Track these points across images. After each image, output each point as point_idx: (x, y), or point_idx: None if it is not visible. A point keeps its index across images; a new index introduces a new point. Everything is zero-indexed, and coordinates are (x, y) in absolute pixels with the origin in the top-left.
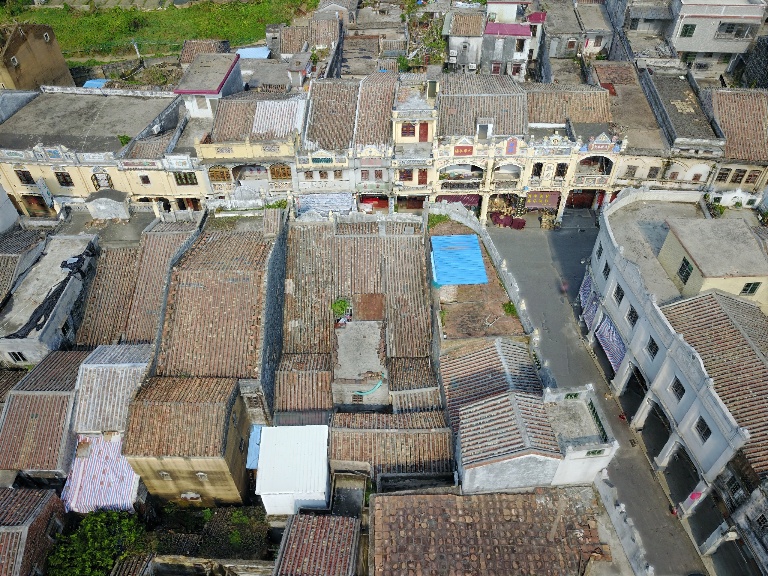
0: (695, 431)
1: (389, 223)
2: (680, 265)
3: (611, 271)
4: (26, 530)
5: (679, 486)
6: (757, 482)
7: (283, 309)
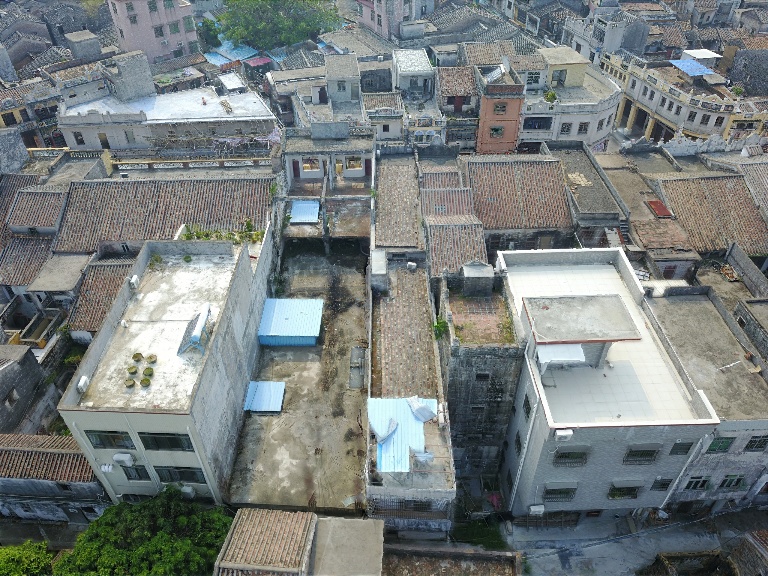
0: None
1: None
2: None
3: None
4: None
5: None
6: None
7: None
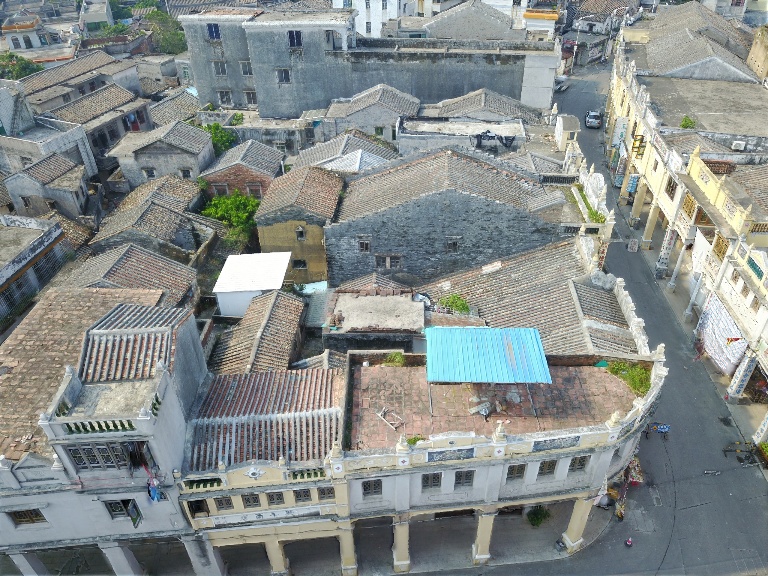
0: None
1: (628, 340)
2: None
3: None
4: (236, 162)
5: None
6: None
7: (463, 272)
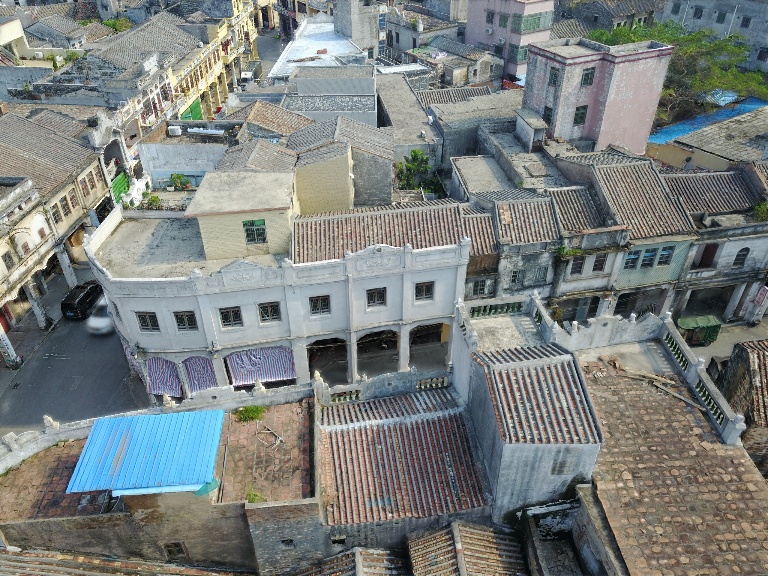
0: (418, 302)
1: None
2: (244, 234)
3: (201, 308)
4: None
5: (424, 365)
6: (495, 259)
7: None
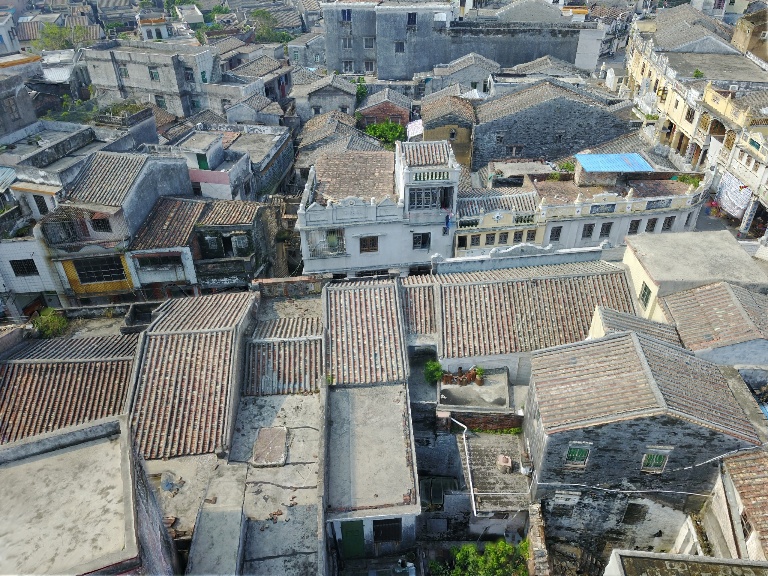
0: None
1: None
2: None
3: None
4: (385, 100)
5: None
6: None
7: (563, 157)
